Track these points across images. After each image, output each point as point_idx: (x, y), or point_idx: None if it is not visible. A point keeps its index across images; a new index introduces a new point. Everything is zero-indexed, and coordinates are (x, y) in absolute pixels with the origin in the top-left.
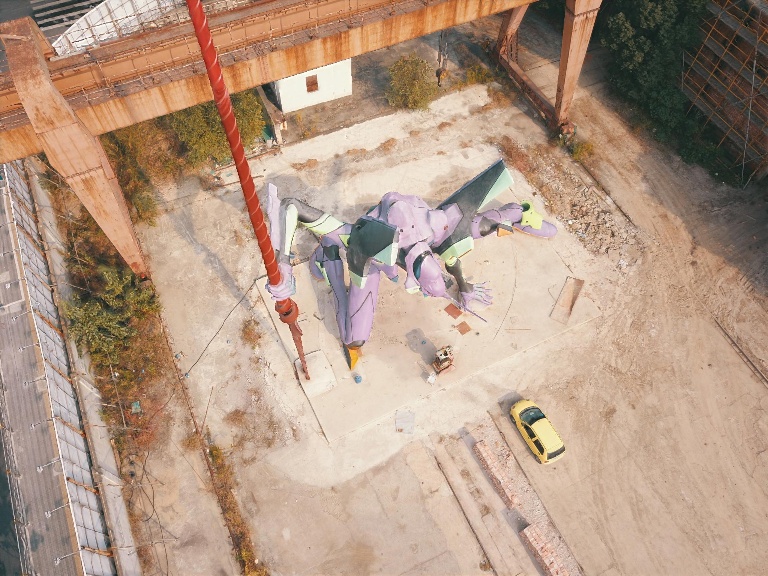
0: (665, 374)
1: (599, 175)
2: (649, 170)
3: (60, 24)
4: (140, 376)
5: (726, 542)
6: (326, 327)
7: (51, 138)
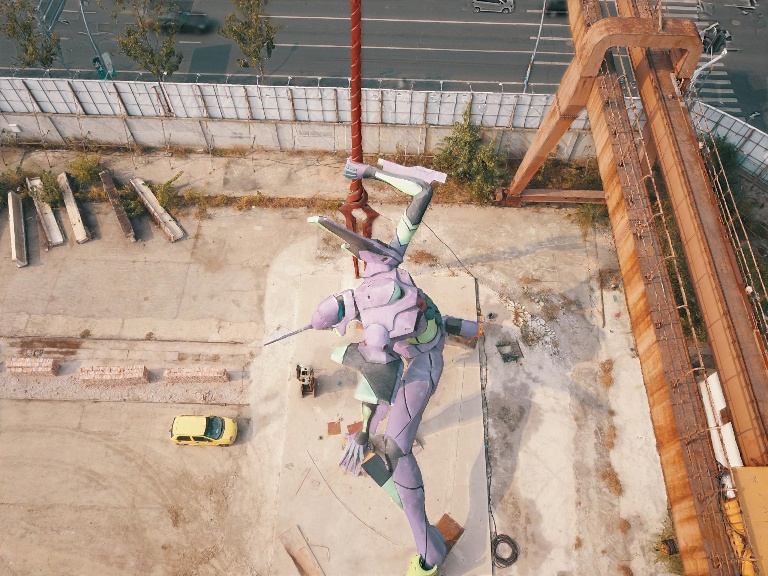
0: None
1: None
2: None
3: None
4: None
5: (16, 538)
6: None
7: (574, 66)
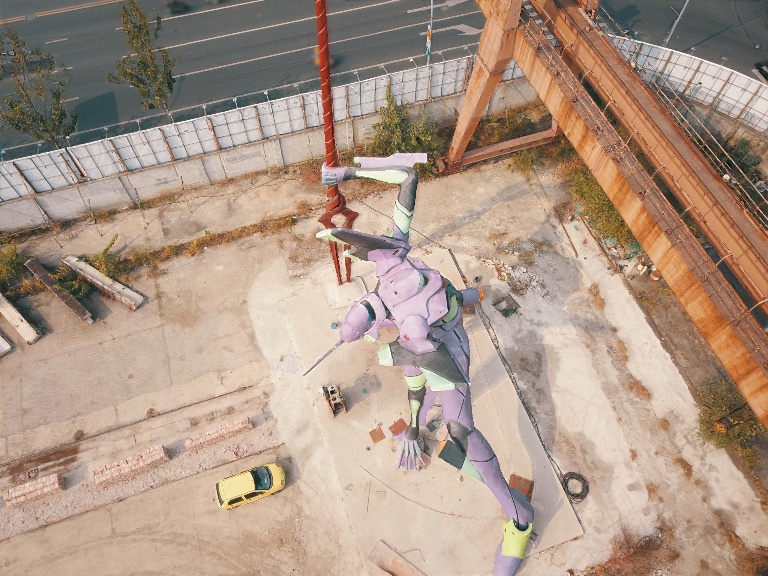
0: None
1: None
2: None
3: (767, 82)
4: None
5: None
6: None
7: (492, 23)
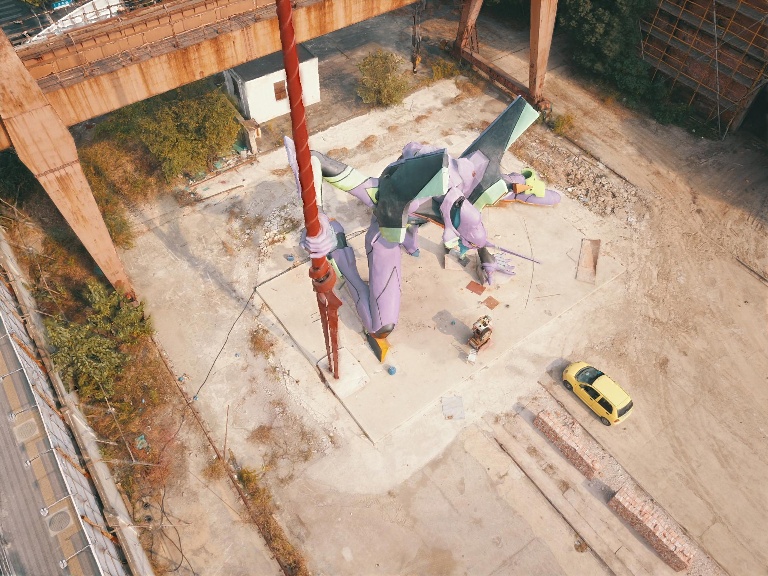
0: (706, 317)
1: (584, 145)
2: (630, 135)
3: None
4: (140, 407)
5: None
6: (344, 323)
7: (20, 125)
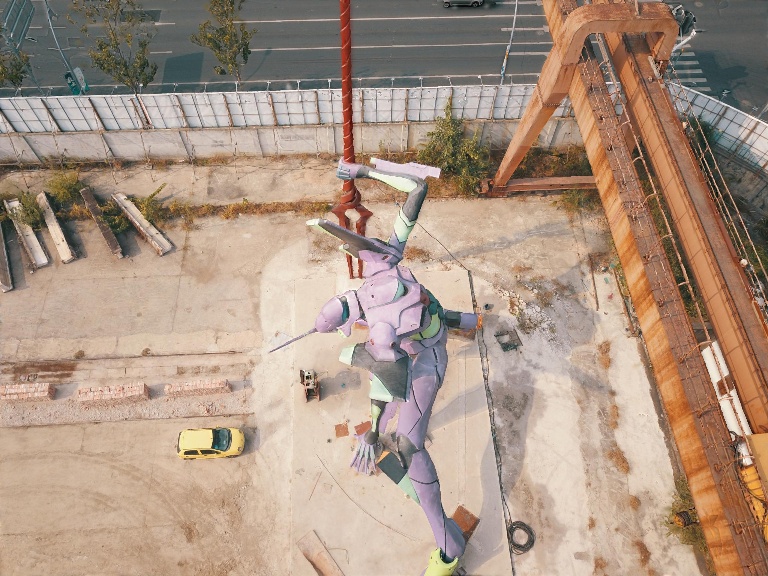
0: None
1: None
2: None
3: None
4: None
5: (26, 569)
6: None
7: (554, 54)
